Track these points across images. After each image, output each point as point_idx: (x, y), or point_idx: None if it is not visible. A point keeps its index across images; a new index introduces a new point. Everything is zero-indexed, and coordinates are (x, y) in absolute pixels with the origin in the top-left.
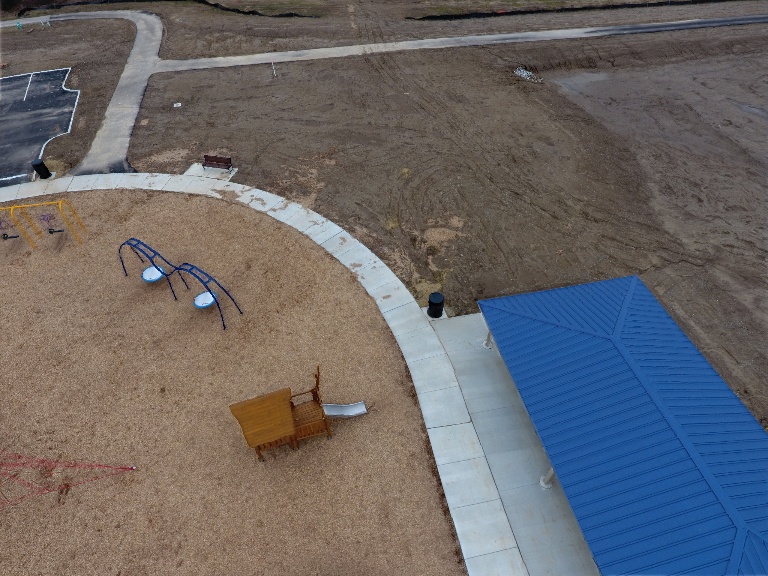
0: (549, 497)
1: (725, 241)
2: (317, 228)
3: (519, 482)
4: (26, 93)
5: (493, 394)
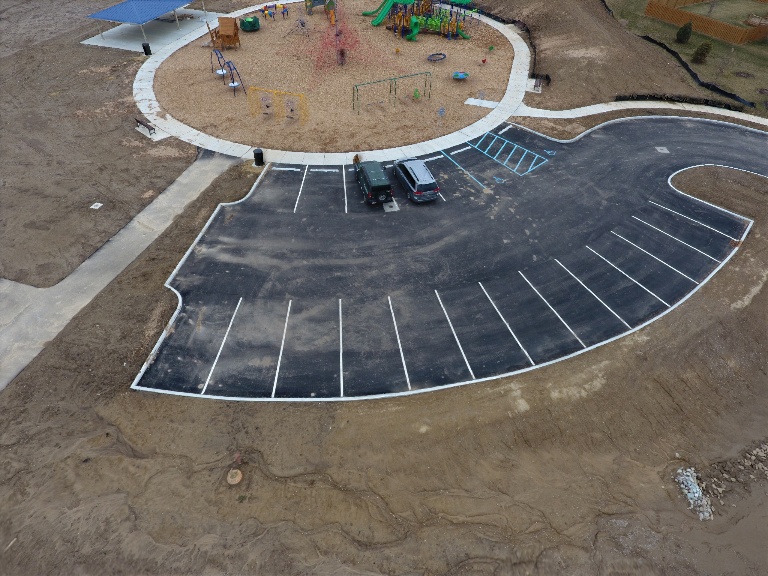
0: None
1: (4, 48)
2: (144, 87)
3: None
4: (233, 318)
5: None
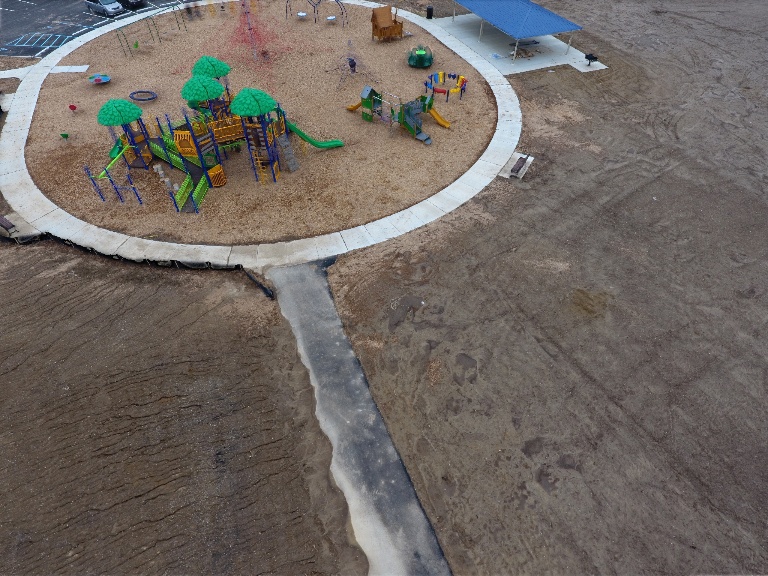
0: (481, 43)
1: (549, 1)
2: (366, 4)
3: (471, 42)
4: None
5: (458, 30)
